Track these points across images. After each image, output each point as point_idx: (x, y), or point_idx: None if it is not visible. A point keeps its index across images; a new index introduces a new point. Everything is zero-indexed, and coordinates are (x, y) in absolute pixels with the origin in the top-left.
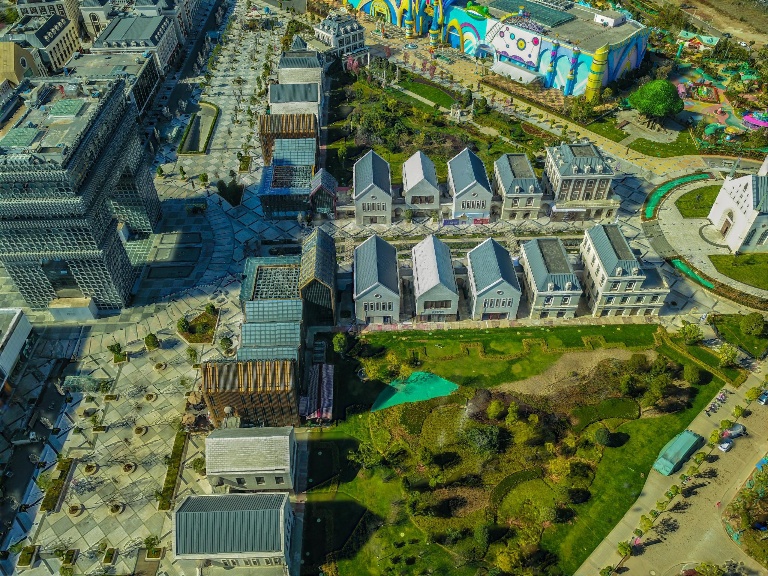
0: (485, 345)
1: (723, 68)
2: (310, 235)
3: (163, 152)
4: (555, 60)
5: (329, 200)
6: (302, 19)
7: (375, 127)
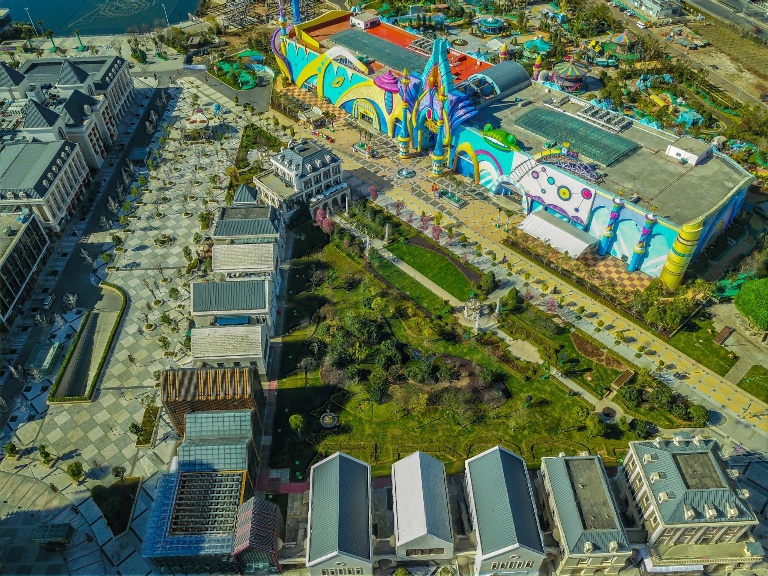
0: None
1: None
2: None
3: (21, 408)
4: (615, 222)
5: (266, 556)
6: (262, 124)
7: (351, 354)
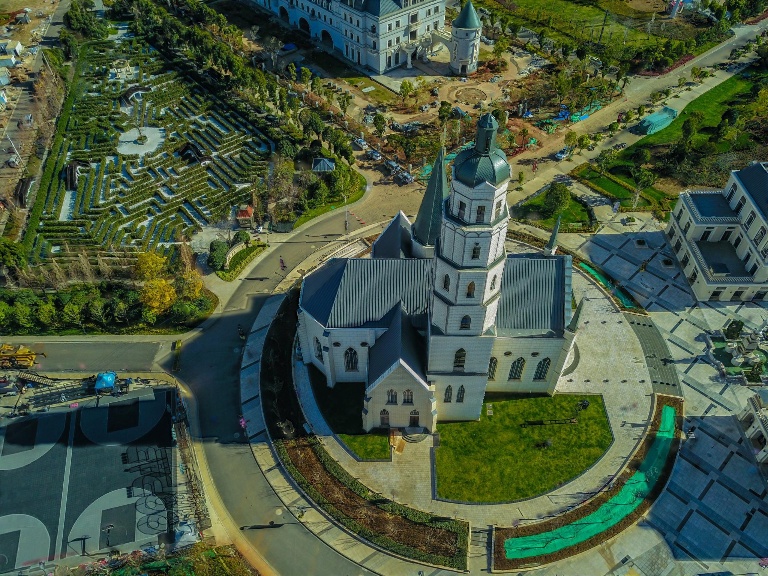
0: None
1: None
2: None
3: None
4: None
5: None
6: None
7: None
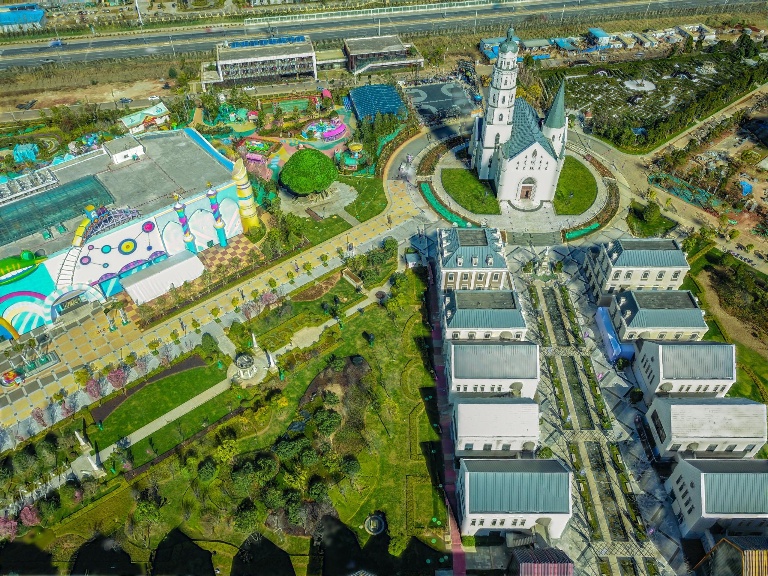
0: None
1: (211, 121)
2: (754, 568)
3: None
4: None
5: None
6: None
7: (296, 488)
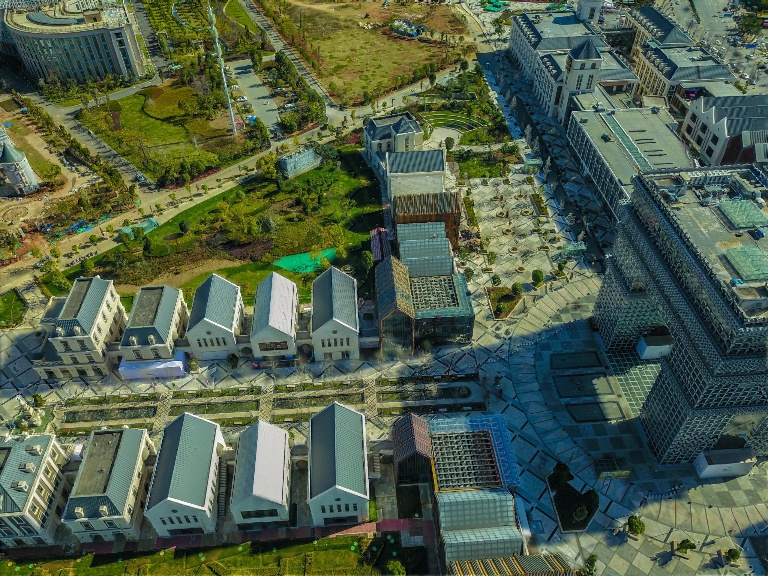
0: (242, 293)
1: None
2: None
3: None
4: None
5: None
6: None
7: None
